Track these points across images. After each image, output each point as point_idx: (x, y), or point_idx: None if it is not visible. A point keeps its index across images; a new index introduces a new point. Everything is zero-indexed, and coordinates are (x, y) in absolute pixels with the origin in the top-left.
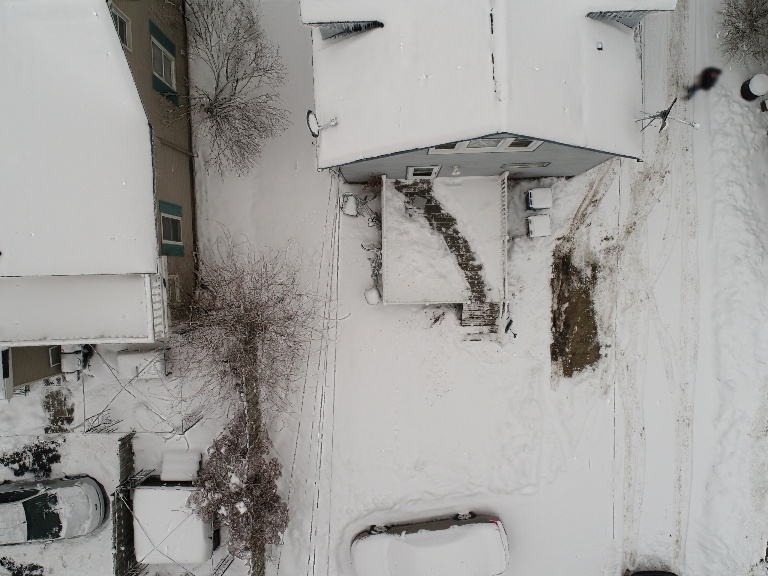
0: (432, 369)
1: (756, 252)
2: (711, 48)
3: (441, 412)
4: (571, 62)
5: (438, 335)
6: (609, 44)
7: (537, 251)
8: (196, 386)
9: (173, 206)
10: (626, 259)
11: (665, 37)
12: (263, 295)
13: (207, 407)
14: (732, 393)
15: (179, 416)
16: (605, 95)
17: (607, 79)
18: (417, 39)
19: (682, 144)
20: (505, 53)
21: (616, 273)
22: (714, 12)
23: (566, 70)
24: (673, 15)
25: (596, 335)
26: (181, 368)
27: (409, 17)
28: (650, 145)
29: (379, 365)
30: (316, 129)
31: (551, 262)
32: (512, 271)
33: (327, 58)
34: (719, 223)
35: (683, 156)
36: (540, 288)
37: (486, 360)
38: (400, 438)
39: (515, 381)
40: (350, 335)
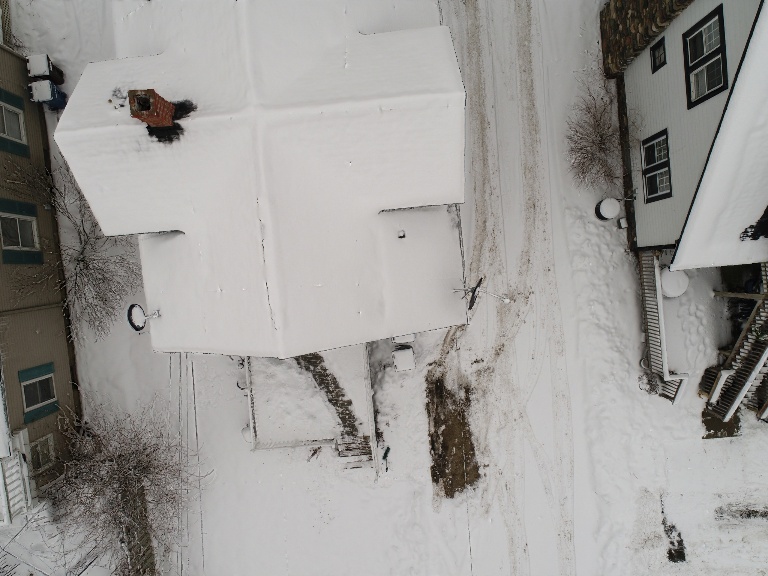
0: (316, 498)
1: (621, 368)
2: (564, 171)
3: (329, 539)
4: (365, 263)
5: (318, 466)
6: (413, 229)
7: (410, 377)
8: (77, 540)
9: (40, 367)
10: (497, 381)
11: (519, 162)
12: (134, 449)
13: (92, 557)
14: (608, 507)
15: (63, 569)
16: (411, 280)
17: (413, 264)
18: (211, 252)
19: (544, 264)
20: (276, 284)
21: (488, 394)
22: (563, 136)
23: (359, 272)
24: (525, 139)
25: (474, 455)
26: (61, 523)
27: (203, 229)
28: (512, 268)
29: (265, 496)
30: (142, 320)
31: (424, 387)
32: (385, 400)
33: (148, 250)
34: (584, 341)
35: (545, 276)
36: (416, 413)
37: (369, 485)
38: (291, 566)
39: (398, 505)
40: (235, 469)
